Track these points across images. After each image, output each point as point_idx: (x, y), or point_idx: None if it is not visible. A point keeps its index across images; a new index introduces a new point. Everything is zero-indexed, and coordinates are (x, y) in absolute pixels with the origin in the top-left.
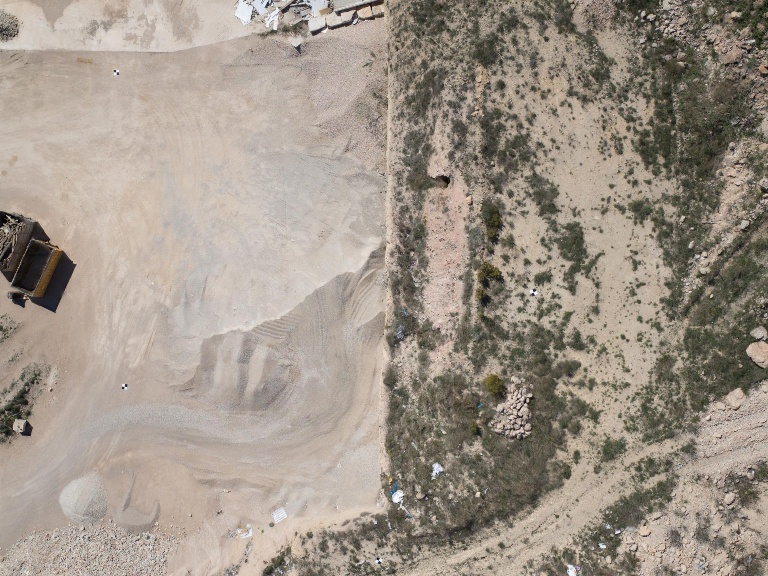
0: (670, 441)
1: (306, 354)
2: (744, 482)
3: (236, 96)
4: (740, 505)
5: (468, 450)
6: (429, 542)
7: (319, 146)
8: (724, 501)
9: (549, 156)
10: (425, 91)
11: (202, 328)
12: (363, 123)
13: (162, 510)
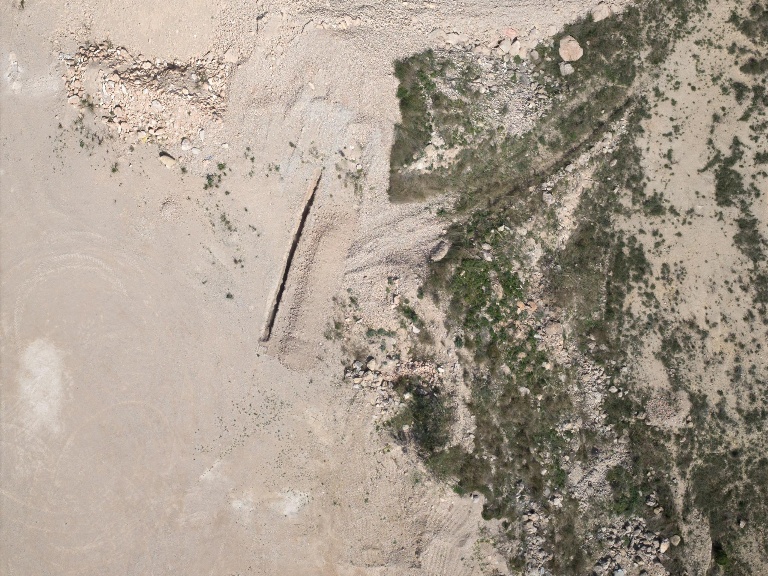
0: None
1: None
2: None
3: None
4: None
5: None
6: None
7: None
8: None
9: (737, 276)
10: None
11: None
12: None
13: None
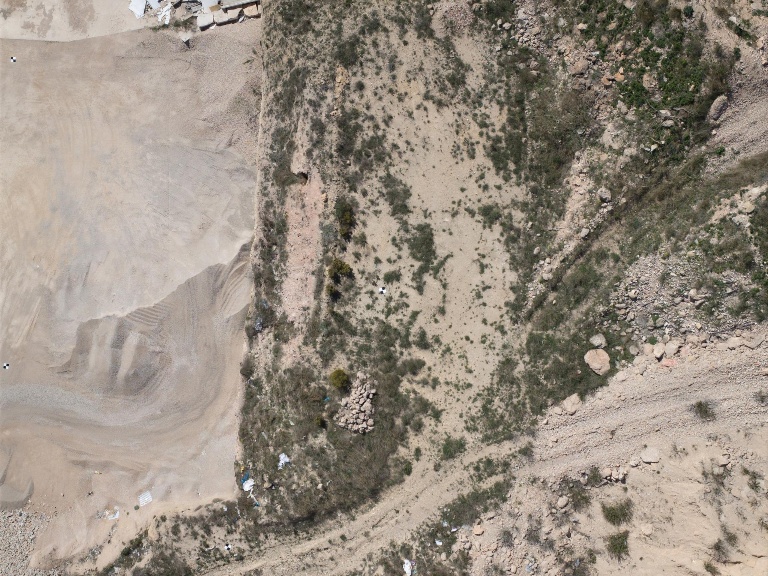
0: (509, 443)
1: (177, 342)
2: (578, 487)
3: (127, 87)
4: (573, 509)
5: (312, 442)
6: (275, 531)
7: (204, 139)
8: (557, 504)
9: (403, 158)
10: (290, 89)
11: (81, 312)
12: (244, 119)
13: (35, 488)
